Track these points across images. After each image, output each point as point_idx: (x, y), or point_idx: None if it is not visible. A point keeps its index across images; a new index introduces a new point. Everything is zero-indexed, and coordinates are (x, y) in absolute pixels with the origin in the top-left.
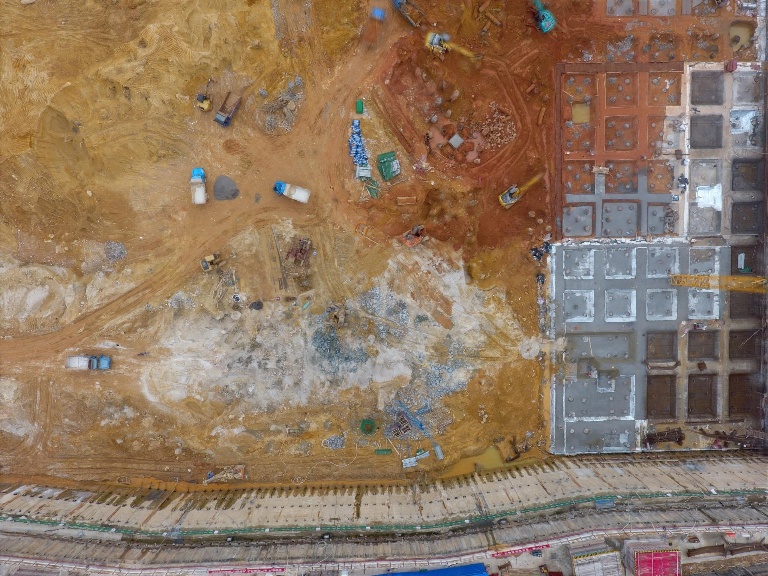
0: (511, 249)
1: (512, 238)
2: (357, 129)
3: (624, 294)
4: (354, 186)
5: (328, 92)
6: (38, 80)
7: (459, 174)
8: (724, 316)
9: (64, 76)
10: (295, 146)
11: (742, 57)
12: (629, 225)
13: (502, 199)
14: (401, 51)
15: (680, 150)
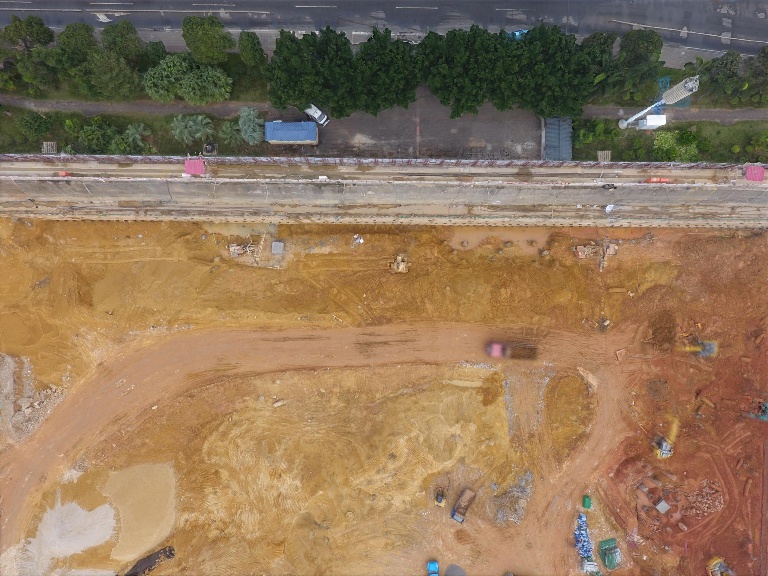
0: None
1: None
2: (584, 525)
3: None
4: (578, 575)
5: (556, 486)
6: (292, 488)
7: (666, 541)
8: None
9: (312, 476)
10: (523, 538)
11: None
12: None
13: (712, 575)
14: (629, 451)
15: None
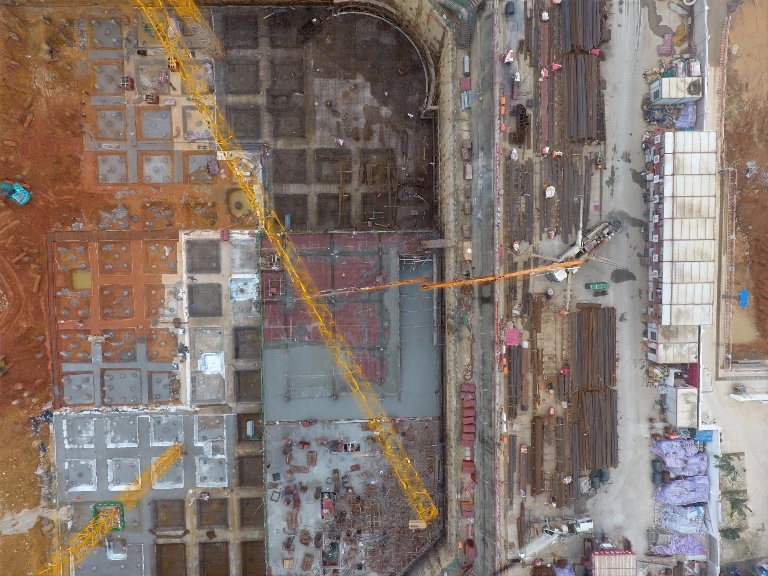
0: (7, 418)
1: (6, 408)
2: None
3: (131, 462)
4: None
5: None
6: None
7: None
8: (232, 484)
9: None
10: None
11: (244, 223)
12: (133, 392)
13: None
14: None
15: (179, 318)
